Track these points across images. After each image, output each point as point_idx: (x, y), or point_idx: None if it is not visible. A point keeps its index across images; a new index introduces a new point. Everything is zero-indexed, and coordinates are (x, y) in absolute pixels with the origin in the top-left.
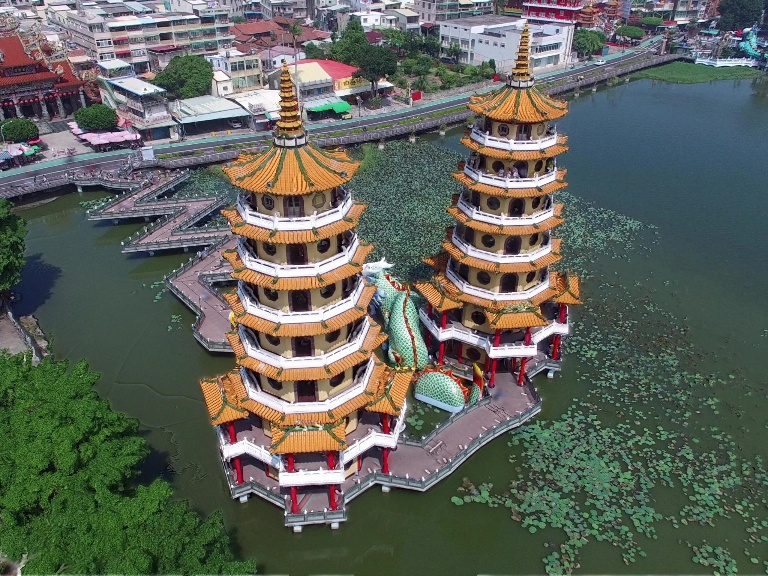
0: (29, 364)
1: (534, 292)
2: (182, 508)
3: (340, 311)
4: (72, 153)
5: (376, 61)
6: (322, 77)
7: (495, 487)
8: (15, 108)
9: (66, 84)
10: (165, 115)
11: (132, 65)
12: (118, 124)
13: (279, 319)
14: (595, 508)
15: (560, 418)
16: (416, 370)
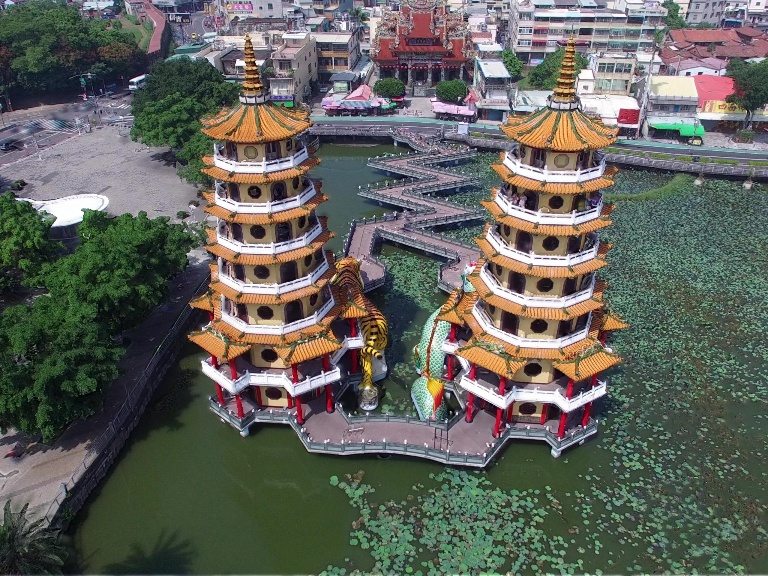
0: (203, 234)
1: (532, 344)
2: (93, 328)
3: (259, 252)
4: (419, 115)
5: (754, 86)
6: (685, 94)
7: (374, 494)
8: (408, 72)
9: (452, 59)
10: (504, 99)
11: (544, 54)
12: (465, 99)
13: (218, 239)
14: (425, 572)
15: (508, 490)
16: (378, 356)
